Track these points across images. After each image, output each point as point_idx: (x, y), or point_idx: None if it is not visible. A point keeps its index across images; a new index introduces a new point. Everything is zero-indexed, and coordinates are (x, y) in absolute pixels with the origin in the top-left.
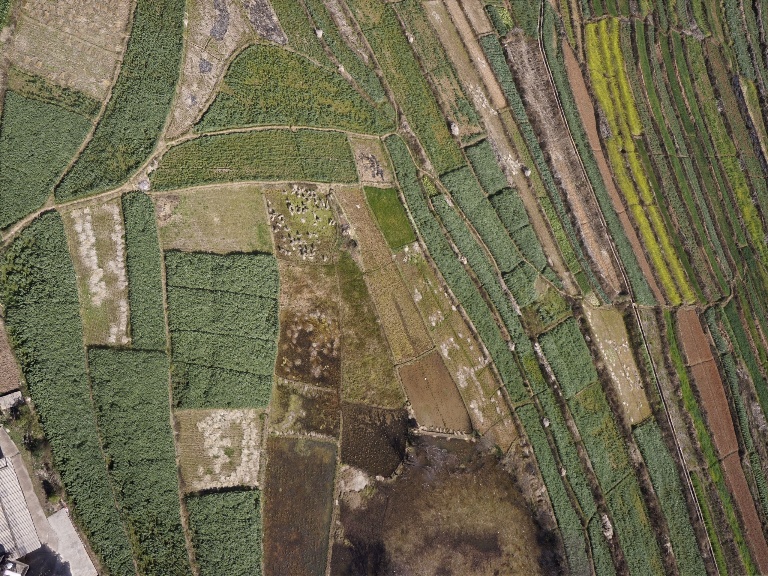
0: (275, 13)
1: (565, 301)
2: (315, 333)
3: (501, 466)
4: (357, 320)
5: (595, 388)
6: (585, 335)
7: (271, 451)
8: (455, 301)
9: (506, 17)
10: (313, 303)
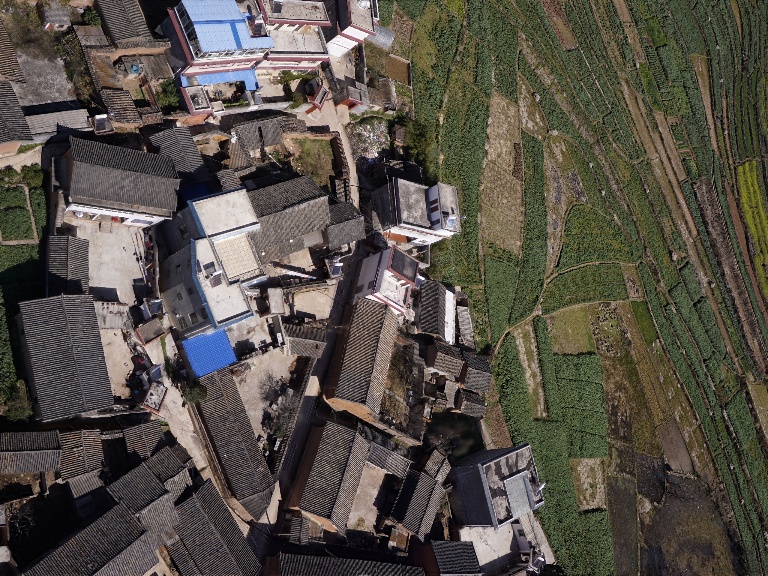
0: (580, 180)
1: (736, 379)
2: (618, 406)
3: (710, 497)
4: (636, 396)
5: (755, 442)
6: (748, 403)
7: (608, 485)
8: (680, 381)
9: (694, 167)
10: (616, 386)
